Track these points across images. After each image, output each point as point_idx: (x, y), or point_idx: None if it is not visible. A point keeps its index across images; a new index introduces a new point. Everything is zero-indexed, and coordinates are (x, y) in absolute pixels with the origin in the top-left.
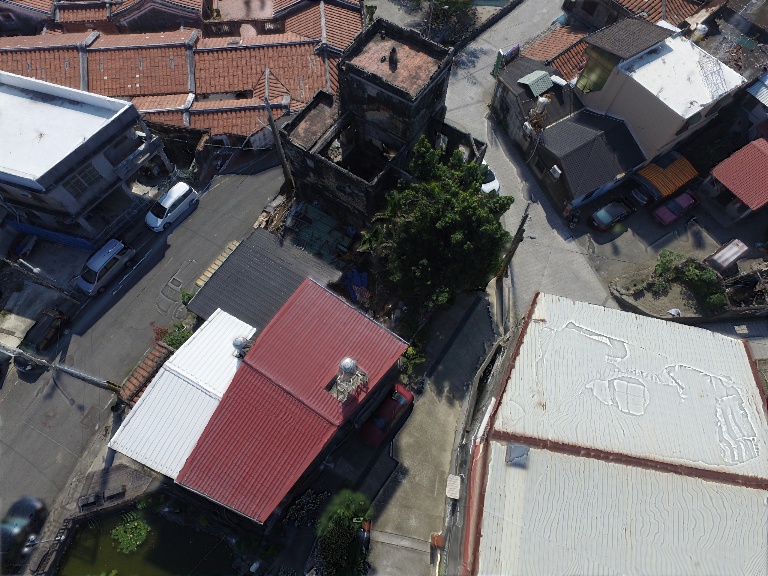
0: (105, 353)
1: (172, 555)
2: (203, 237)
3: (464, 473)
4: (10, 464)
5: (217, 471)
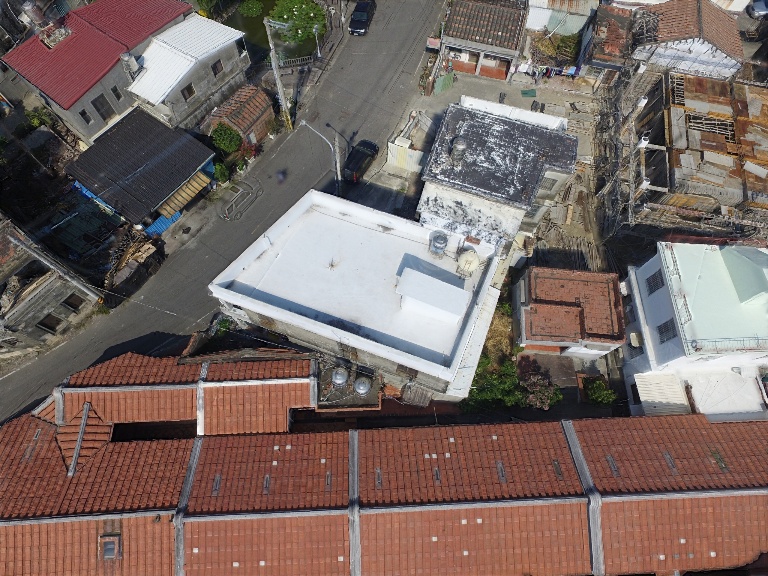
0: (308, 156)
1: (251, 49)
2: (220, 255)
3: (7, 6)
4: (364, 93)
5: (162, 6)
